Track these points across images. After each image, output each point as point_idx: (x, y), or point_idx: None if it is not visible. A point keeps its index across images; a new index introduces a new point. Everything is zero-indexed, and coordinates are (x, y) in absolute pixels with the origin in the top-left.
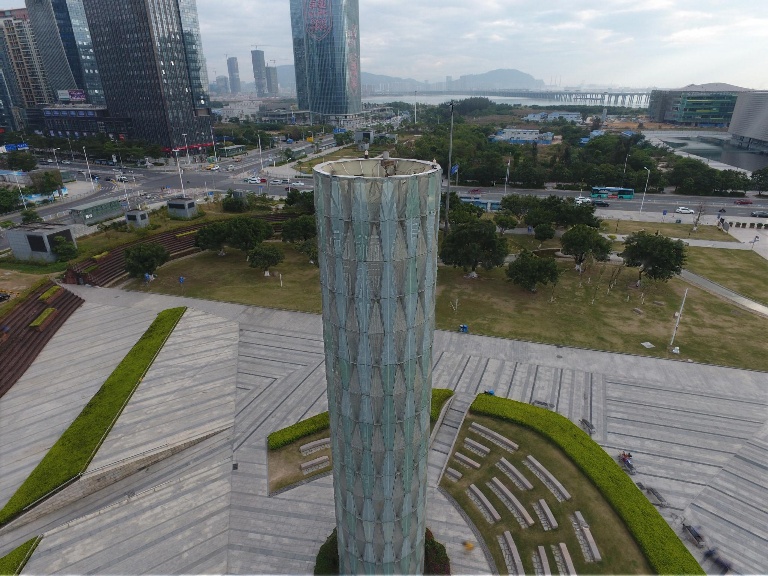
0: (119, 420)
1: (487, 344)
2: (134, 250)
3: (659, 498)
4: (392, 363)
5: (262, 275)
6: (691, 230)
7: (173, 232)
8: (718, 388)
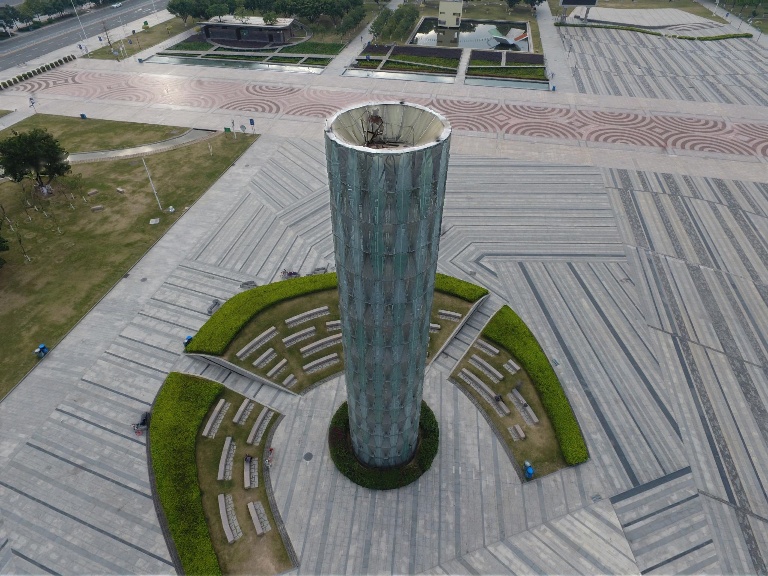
0: None
1: (88, 333)
2: None
3: None
4: None
5: None
6: None
7: None
8: (224, 208)
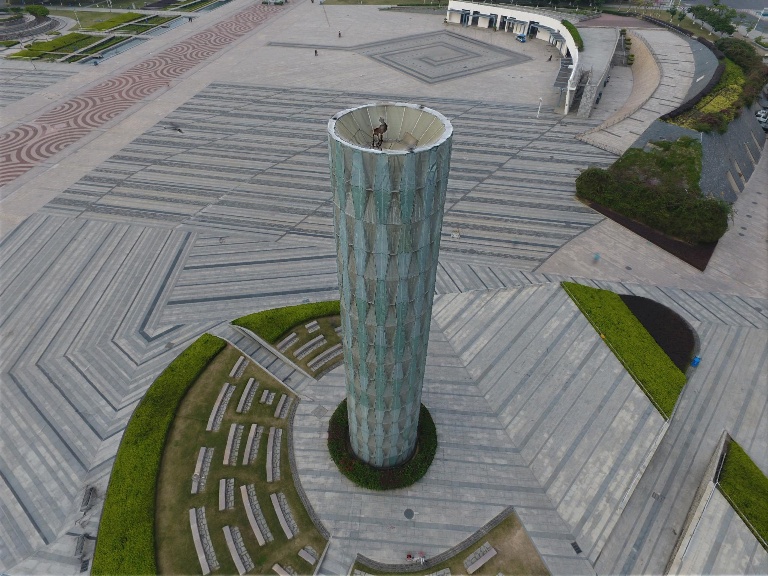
0: None
1: None
2: None
3: None
4: None
5: None
6: None
7: None
8: None
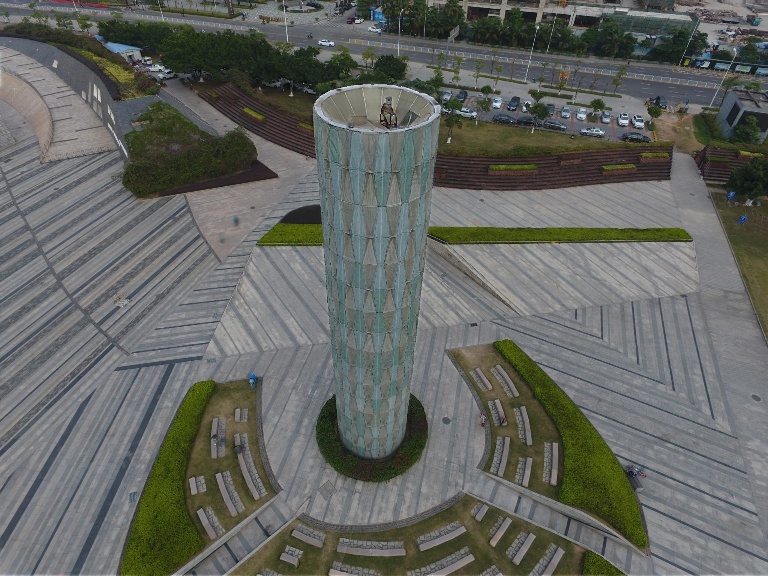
0: (502, 245)
1: None
2: (759, 164)
3: None
4: None
5: None
6: None
7: None
8: None
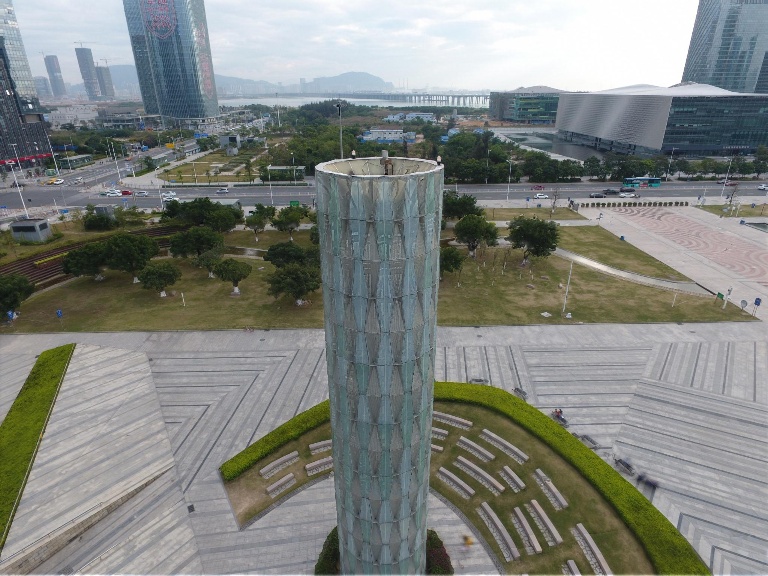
0: (27, 489)
1: None
2: None
3: (593, 442)
4: (411, 359)
5: (157, 296)
6: (551, 212)
7: (29, 259)
8: (607, 342)
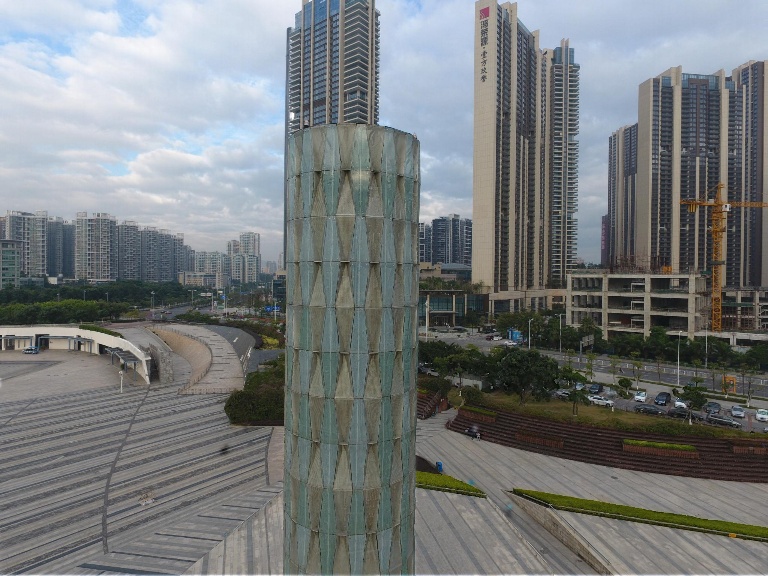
0: (640, 524)
1: None
2: None
3: None
4: None
5: None
6: None
7: None
8: None
